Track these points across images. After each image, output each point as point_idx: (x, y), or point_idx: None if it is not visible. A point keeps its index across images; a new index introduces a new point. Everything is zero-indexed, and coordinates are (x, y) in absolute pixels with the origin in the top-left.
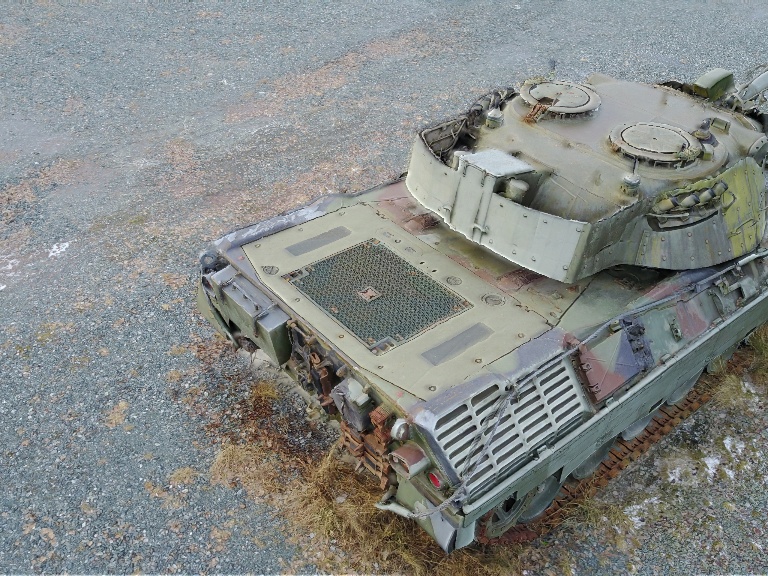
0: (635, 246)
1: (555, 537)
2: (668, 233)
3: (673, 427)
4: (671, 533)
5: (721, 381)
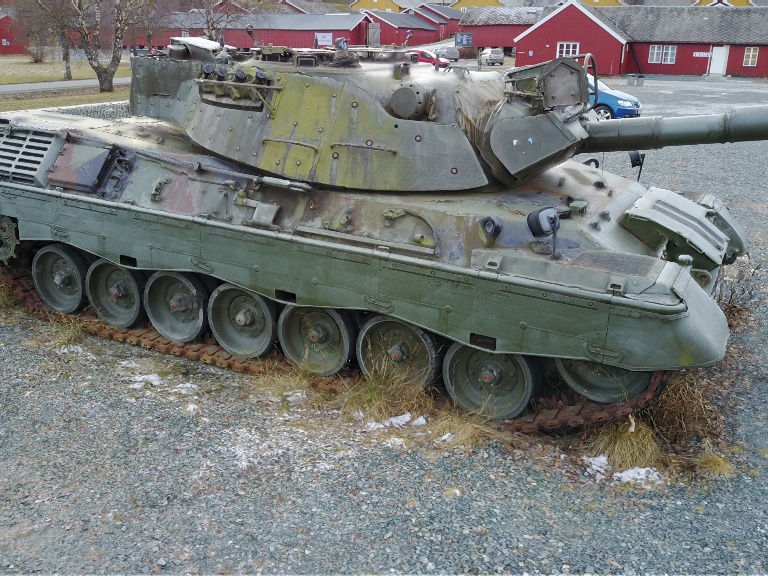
0: (188, 110)
1: (37, 320)
2: (207, 106)
3: (204, 363)
4: (47, 362)
5: (288, 374)
